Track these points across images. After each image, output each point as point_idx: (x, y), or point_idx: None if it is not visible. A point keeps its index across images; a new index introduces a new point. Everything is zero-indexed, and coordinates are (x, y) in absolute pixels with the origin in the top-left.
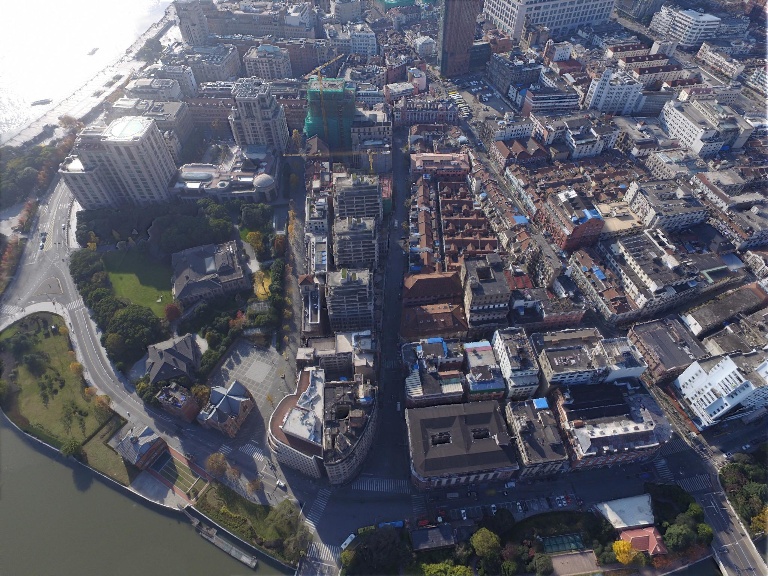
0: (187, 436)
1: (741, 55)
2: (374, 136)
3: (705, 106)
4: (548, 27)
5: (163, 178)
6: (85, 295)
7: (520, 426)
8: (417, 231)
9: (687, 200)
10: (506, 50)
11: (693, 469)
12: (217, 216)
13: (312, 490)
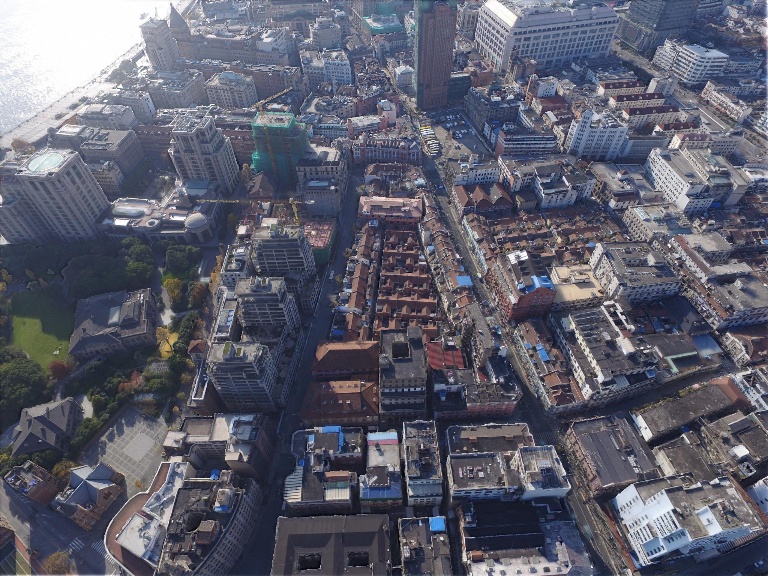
0: (39, 523)
1: (750, 96)
2: (322, 176)
3: (696, 156)
4: (540, 59)
5: (88, 214)
6: None
7: (403, 556)
8: (351, 286)
9: (659, 268)
10: (488, 83)
11: None
12: (138, 258)
13: None
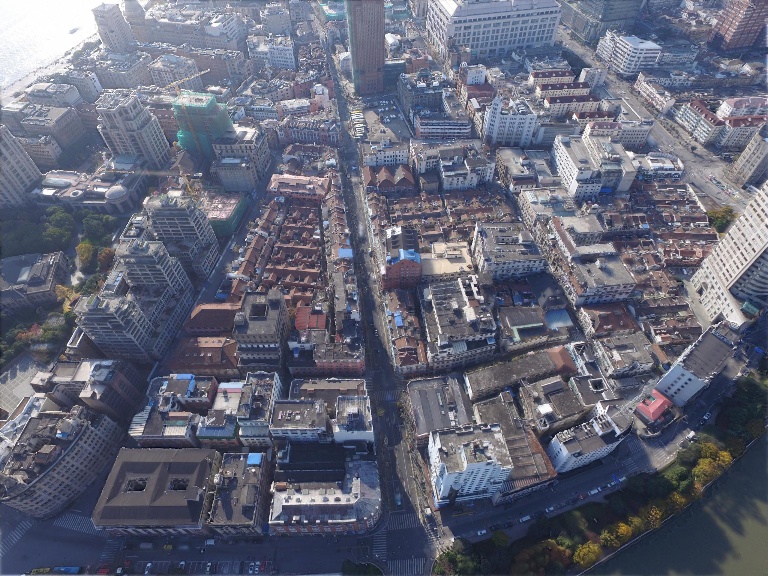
0: None
1: (680, 87)
2: (238, 154)
3: (594, 143)
4: (482, 47)
5: (17, 183)
6: None
7: None
8: None
9: (526, 246)
10: None
11: (412, 550)
12: (58, 225)
13: (15, 521)
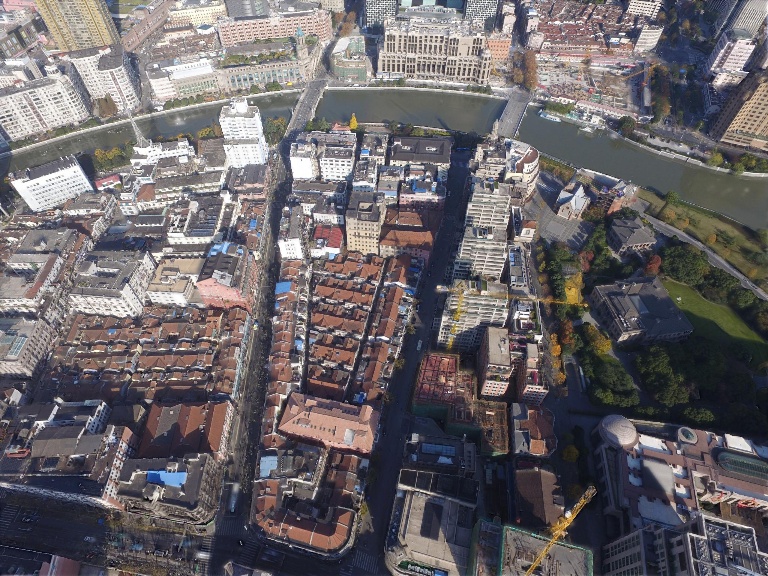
0: None
1: None
2: None
3: None
4: None
5: None
6: (762, 300)
7: None
8: None
9: None
10: None
11: (289, 147)
12: None
13: None
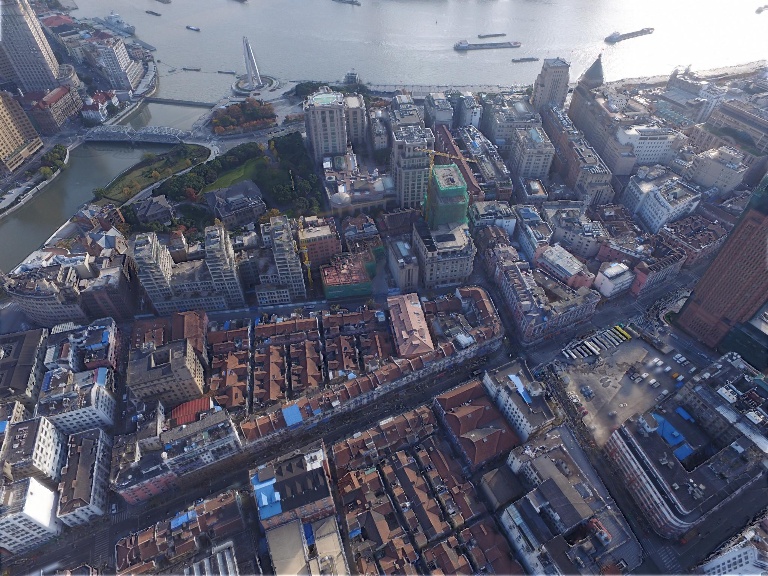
0: None
1: None
2: None
3: None
4: None
5: (322, 146)
6: None
7: None
8: None
9: None
10: None
11: None
12: None
13: None
